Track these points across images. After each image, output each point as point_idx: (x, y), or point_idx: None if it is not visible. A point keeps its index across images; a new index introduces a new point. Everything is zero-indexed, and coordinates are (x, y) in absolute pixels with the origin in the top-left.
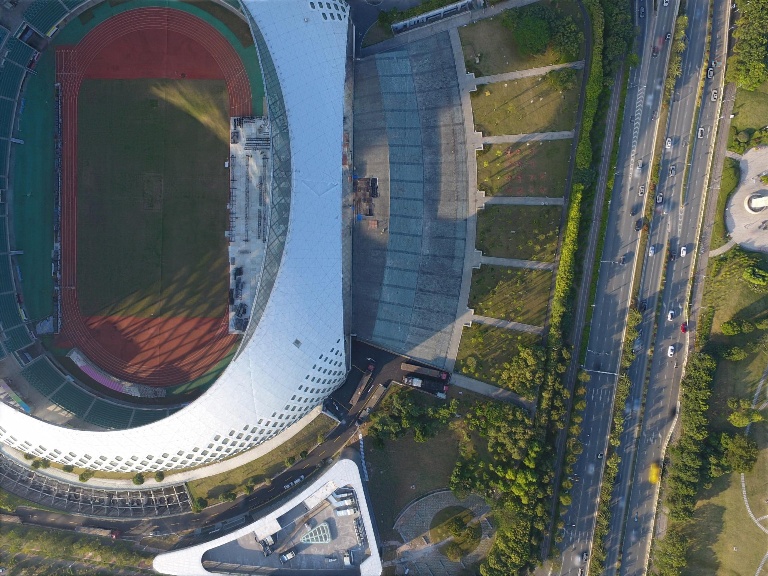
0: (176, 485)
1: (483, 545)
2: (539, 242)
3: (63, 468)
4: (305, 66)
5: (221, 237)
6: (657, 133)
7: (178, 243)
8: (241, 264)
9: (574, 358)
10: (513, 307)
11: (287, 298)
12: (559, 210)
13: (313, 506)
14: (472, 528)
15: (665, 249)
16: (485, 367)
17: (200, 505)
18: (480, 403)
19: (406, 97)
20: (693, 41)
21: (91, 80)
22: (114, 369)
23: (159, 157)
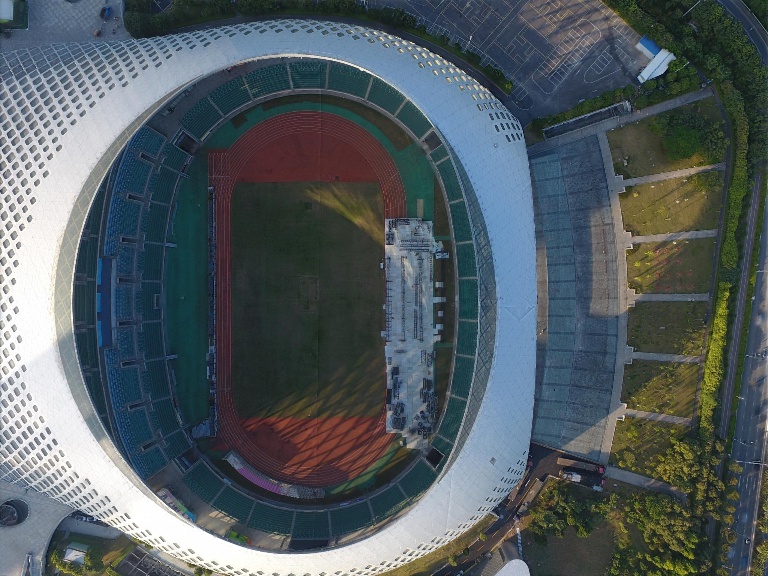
0: None
1: None
2: (687, 337)
3: (228, 575)
4: (501, 193)
5: (377, 337)
6: None
7: (334, 344)
8: (398, 364)
9: None
10: (663, 400)
11: (489, 420)
12: None
13: None
14: None
15: None
16: (638, 459)
17: None
18: None
19: (558, 199)
20: None
21: (244, 183)
22: (271, 471)
23: (314, 259)
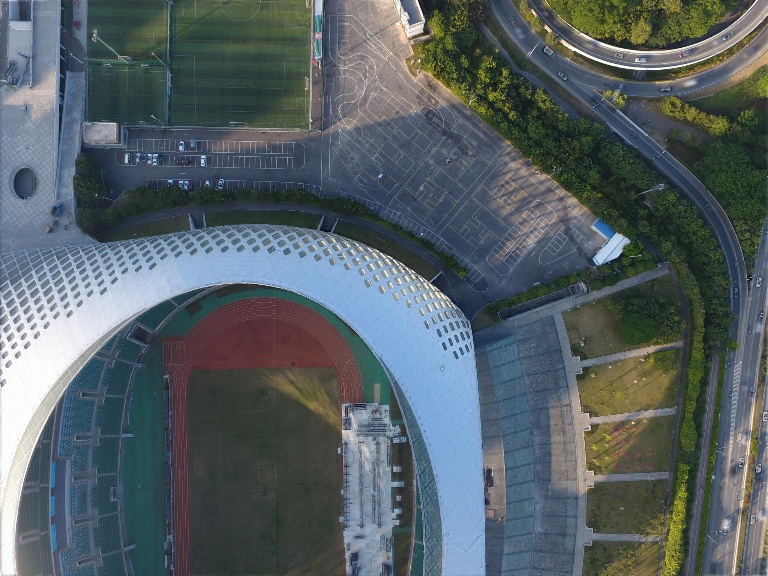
0: None
1: None
2: None
3: None
4: (447, 423)
5: (336, 523)
6: (754, 407)
7: (293, 530)
8: (356, 549)
9: None
10: None
11: None
12: None
13: None
14: None
15: (766, 517)
16: None
17: None
18: None
19: (515, 383)
20: None
21: (200, 371)
22: None
23: (271, 446)
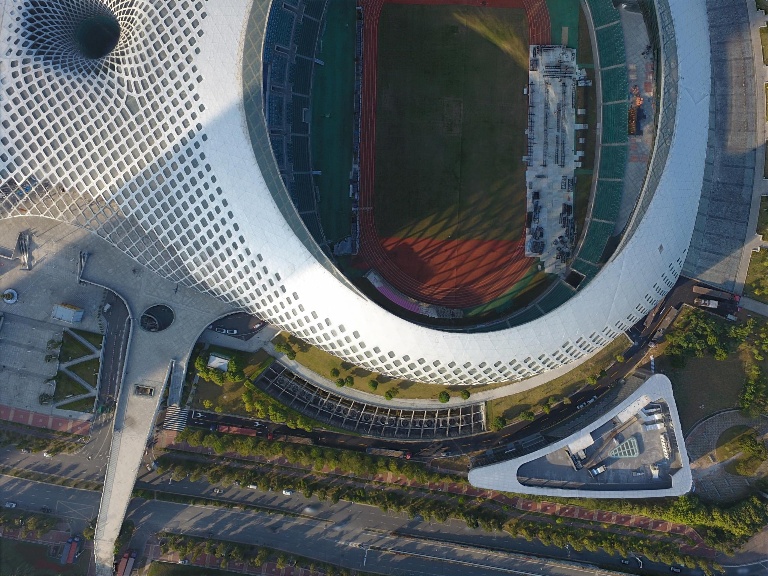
0: (477, 404)
1: (766, 463)
2: None
3: (371, 385)
4: None
5: (519, 162)
6: None
7: (476, 167)
8: (538, 188)
9: None
10: None
11: (664, 202)
12: None
13: (625, 420)
14: (762, 445)
15: None
16: None
17: (502, 423)
18: None
19: None
20: None
21: (392, 5)
22: (410, 290)
23: (459, 82)
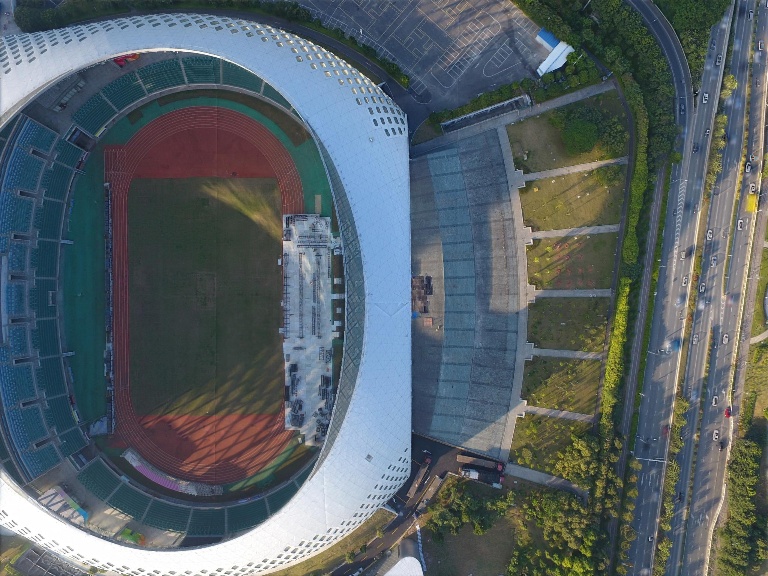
0: None
1: None
2: (588, 333)
3: None
4: (373, 188)
5: (275, 334)
6: (699, 226)
7: (232, 341)
8: (296, 360)
9: (624, 444)
10: (564, 397)
11: (361, 417)
12: (608, 304)
13: None
14: None
15: (708, 337)
16: (538, 456)
17: None
18: (534, 492)
19: (457, 194)
20: (731, 137)
21: (141, 179)
22: (170, 468)
23: (211, 255)
